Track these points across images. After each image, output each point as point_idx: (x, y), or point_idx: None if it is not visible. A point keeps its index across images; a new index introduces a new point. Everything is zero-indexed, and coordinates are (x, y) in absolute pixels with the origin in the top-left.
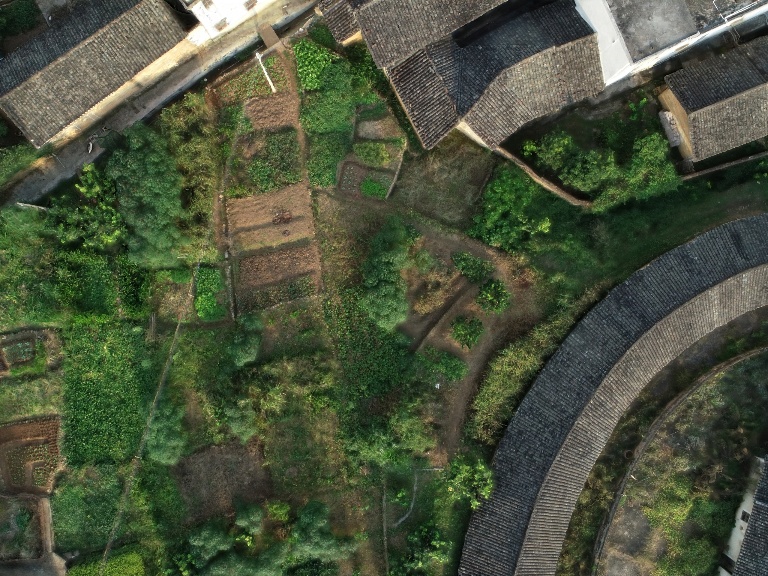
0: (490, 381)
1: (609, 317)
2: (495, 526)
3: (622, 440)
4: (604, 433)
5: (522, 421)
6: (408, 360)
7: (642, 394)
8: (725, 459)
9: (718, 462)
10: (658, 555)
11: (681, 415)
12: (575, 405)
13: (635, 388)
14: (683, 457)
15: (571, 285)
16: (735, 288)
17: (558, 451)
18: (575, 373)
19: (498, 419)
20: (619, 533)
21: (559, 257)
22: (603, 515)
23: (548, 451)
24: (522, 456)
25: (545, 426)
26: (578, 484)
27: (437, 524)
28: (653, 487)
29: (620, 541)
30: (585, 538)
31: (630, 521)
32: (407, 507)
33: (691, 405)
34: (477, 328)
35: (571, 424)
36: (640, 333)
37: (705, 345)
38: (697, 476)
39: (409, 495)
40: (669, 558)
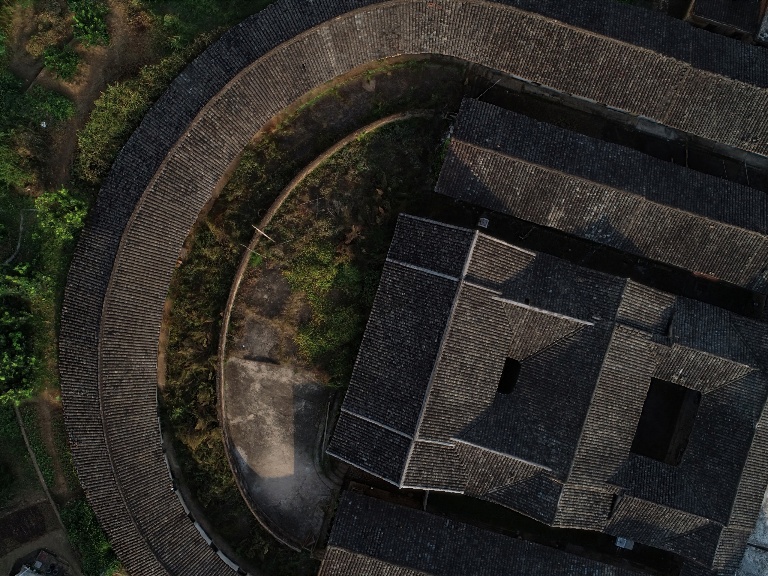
0: (92, 117)
1: (218, 56)
2: (92, 261)
3: (257, 199)
4: (212, 174)
5: (125, 158)
6: (12, 97)
7: (278, 153)
8: (372, 227)
9: (357, 224)
10: (302, 322)
11: (325, 180)
12: (172, 138)
13: (246, 130)
14: (324, 221)
15: (187, 29)
16: (349, 31)
17: (149, 181)
18: (177, 109)
19: (105, 159)
20: (258, 296)
21: (181, 4)
22: (234, 273)
23: (142, 183)
24: (120, 191)
25: (144, 160)
26: (184, 224)
27: (45, 266)
28: (294, 251)
29: (259, 304)
30: (217, 296)
31: (269, 284)
32: (12, 247)
33: (335, 170)
34: (74, 59)
35: (165, 155)
36: (242, 68)
37: (351, 110)
38: (340, 241)
39: (15, 235)
40: (314, 326)
